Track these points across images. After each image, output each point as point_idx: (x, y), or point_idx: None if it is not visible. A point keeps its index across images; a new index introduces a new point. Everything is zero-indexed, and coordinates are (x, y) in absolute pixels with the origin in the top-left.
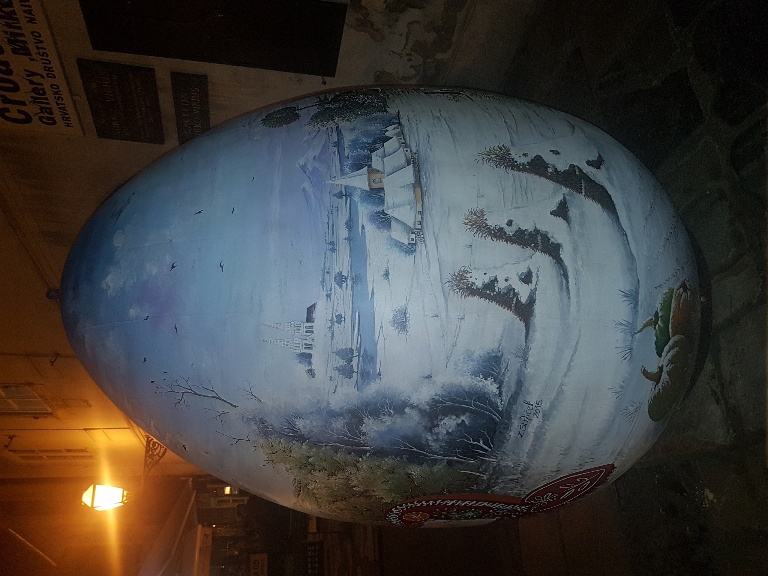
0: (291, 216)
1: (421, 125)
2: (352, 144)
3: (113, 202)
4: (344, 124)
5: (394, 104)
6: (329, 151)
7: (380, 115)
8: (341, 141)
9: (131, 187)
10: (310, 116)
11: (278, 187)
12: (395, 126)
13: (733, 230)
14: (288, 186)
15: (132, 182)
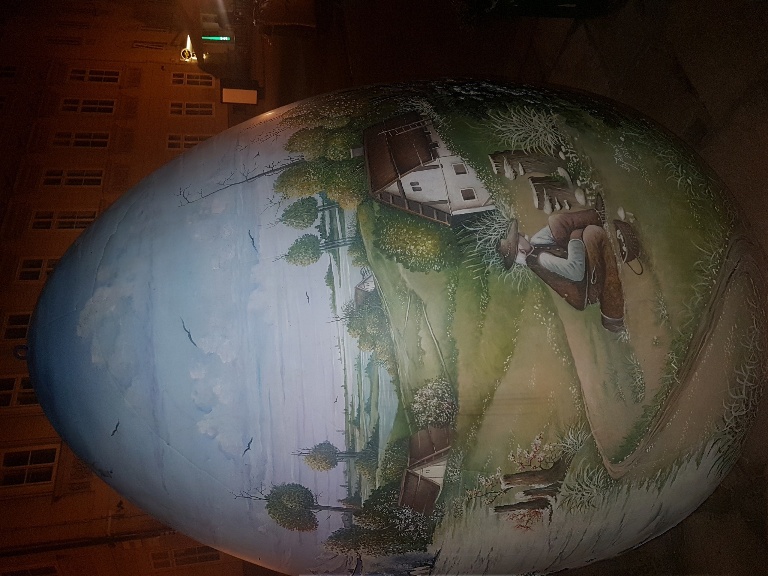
0: (297, 575)
1: (456, 568)
2: (370, 575)
3: (82, 444)
4: (368, 558)
5: (441, 539)
6: (343, 573)
7: (415, 555)
8: (359, 571)
9: (98, 441)
10: (330, 533)
11: (286, 570)
12: (425, 568)
13: (764, 463)
14: (296, 571)
15: (92, 422)
